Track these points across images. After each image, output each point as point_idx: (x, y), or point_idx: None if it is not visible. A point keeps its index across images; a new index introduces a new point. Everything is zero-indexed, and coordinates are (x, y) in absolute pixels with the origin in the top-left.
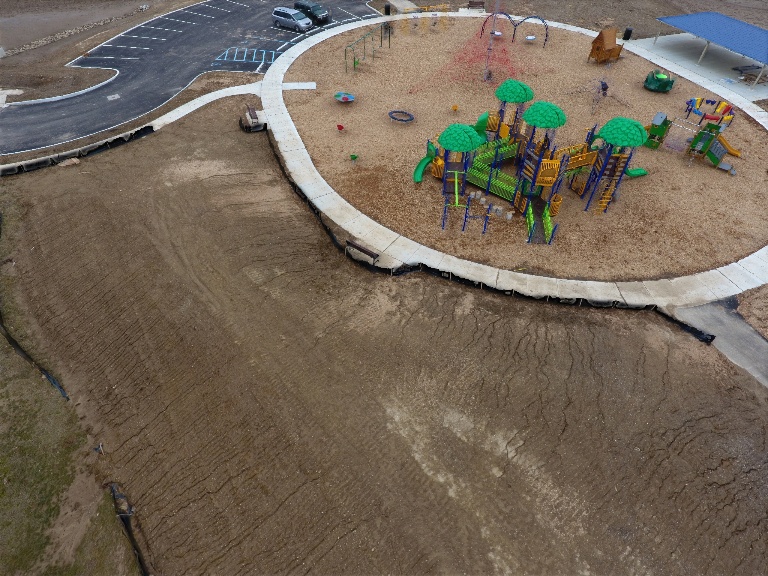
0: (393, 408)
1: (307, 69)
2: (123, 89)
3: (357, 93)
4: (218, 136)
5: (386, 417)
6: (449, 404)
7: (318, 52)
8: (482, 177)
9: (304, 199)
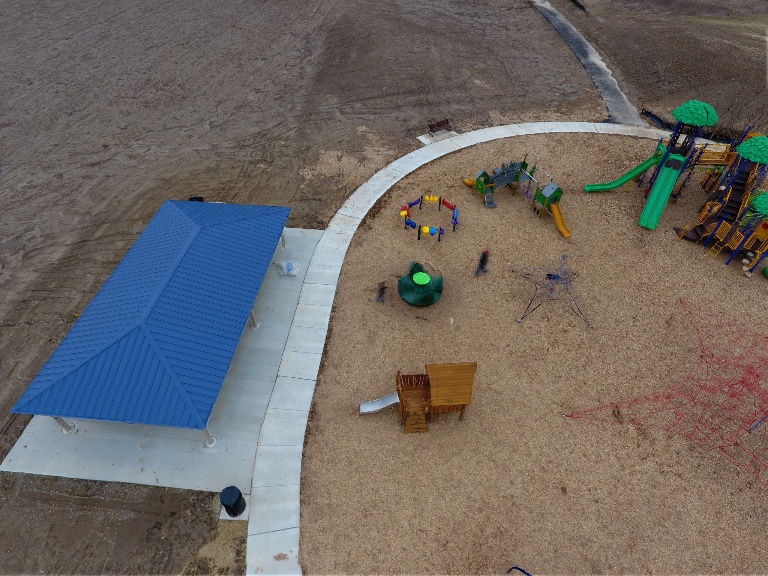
0: None
1: None
2: None
3: None
4: None
5: None
6: None
7: None
8: None
9: None
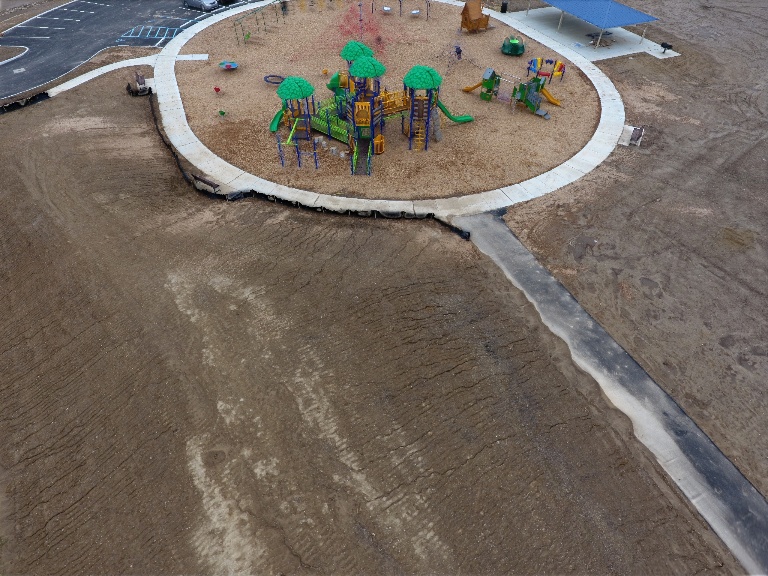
0: (174, 275)
1: (204, 43)
2: (29, 63)
3: (243, 62)
4: (105, 99)
5: (166, 281)
6: (220, 272)
7: (218, 28)
8: (323, 124)
9: (168, 146)
